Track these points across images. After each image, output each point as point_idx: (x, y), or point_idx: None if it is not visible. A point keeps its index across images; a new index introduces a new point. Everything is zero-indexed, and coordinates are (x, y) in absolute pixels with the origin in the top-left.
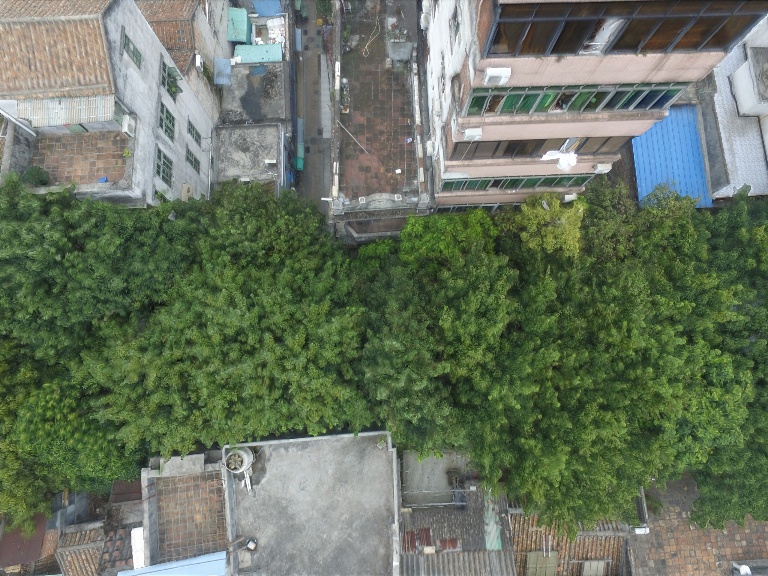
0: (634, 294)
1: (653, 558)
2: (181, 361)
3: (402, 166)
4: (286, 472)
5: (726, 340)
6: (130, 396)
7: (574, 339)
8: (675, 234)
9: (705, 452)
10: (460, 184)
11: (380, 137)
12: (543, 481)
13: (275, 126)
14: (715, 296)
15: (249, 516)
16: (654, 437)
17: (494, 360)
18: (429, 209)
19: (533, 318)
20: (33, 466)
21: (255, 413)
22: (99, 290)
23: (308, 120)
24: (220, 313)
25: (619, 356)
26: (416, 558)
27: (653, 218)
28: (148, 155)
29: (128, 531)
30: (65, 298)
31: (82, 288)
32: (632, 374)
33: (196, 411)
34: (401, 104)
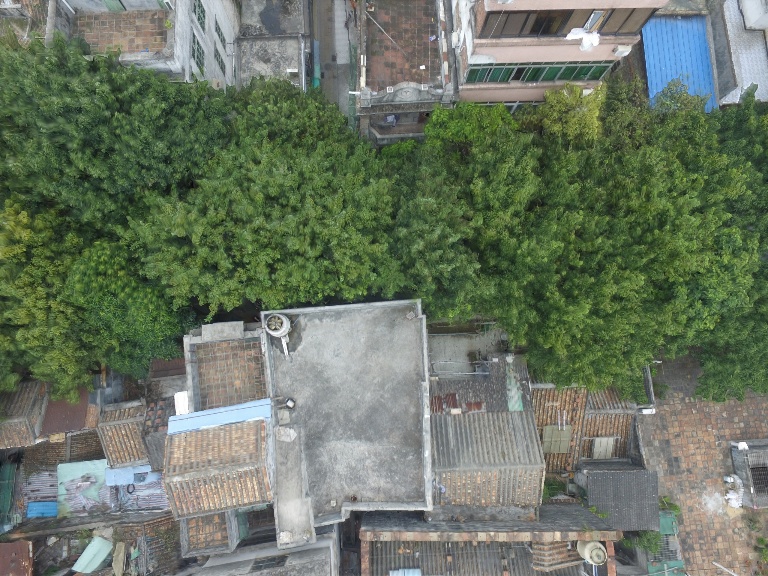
0: (651, 164)
1: (658, 438)
2: (225, 221)
3: (426, 63)
4: (321, 340)
5: (734, 217)
6: (178, 253)
7: (594, 210)
8: (687, 126)
9: (712, 320)
10: (484, 74)
11: (404, 35)
12: (565, 337)
13: (296, 38)
14: (725, 175)
15: (287, 379)
16: (667, 302)
17: (520, 226)
18: (452, 103)
19: (555, 192)
20: (79, 333)
21: (297, 268)
22: (144, 156)
23: (322, 46)
24: (263, 173)
25: (637, 222)
26: (444, 418)
27: (666, 110)
28: (185, 34)
29: (168, 403)
30: (112, 162)
31: (129, 151)
32: (649, 237)
33: (240, 268)
34: (425, 4)
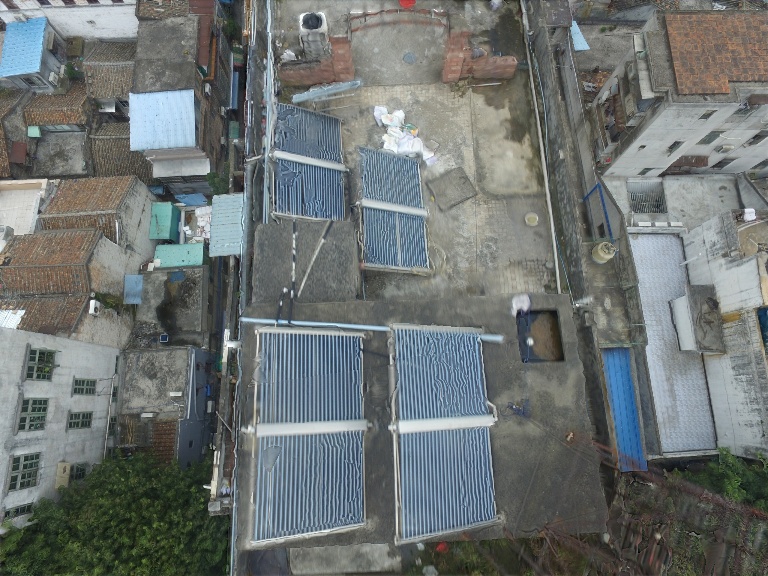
0: None
1: None
2: None
3: None
4: None
5: None
6: None
7: None
8: None
9: None
10: None
11: None
12: None
13: (185, 349)
14: None
15: None
16: None
17: None
18: None
19: None
20: None
21: None
22: None
23: None
24: None
25: None
26: None
27: None
28: None
29: None
30: None
31: None
32: None
33: None
34: None
